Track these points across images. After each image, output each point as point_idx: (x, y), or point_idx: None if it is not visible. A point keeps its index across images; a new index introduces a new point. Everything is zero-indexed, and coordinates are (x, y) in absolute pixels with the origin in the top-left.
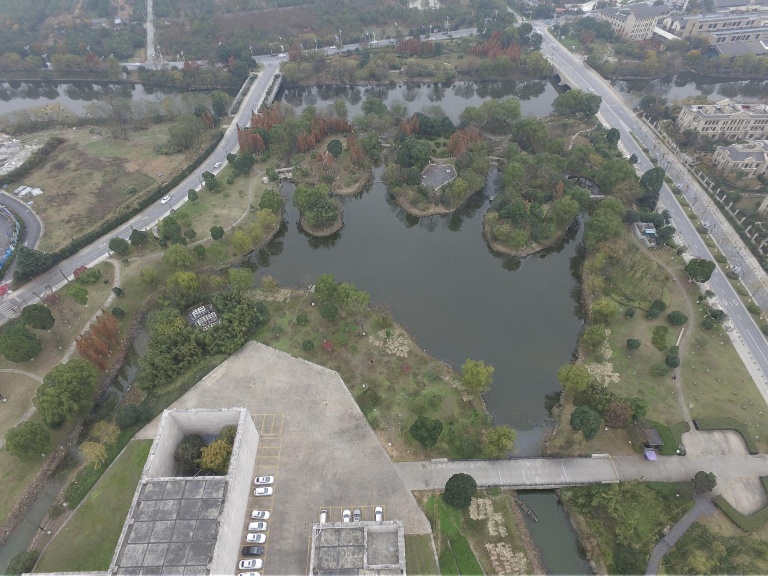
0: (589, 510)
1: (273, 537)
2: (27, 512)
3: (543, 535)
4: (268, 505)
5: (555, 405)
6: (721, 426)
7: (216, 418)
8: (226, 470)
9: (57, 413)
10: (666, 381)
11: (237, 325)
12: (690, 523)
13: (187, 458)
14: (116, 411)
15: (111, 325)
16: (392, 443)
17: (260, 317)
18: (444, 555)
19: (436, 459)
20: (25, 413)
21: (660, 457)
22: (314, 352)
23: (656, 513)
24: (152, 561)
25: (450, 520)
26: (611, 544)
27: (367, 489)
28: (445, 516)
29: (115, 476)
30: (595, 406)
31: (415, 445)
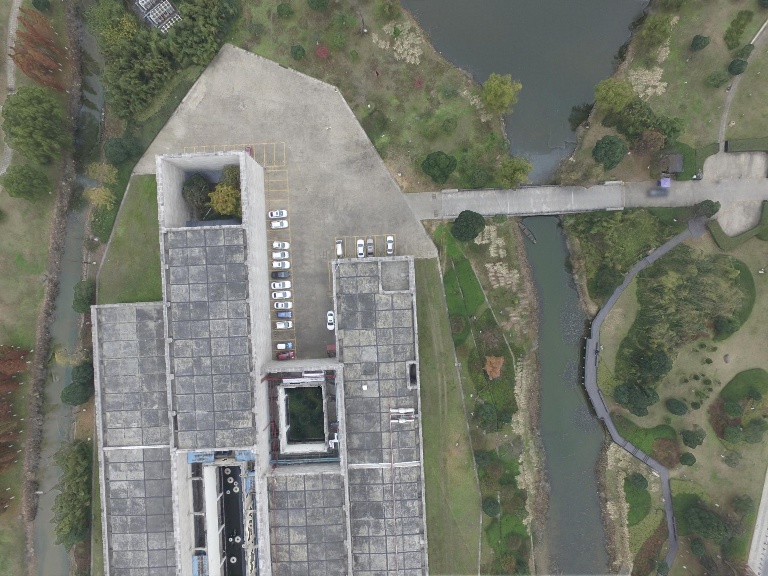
0: (586, 236)
1: (296, 263)
2: (64, 245)
3: (538, 252)
4: (286, 236)
5: (581, 124)
6: (753, 148)
7: (214, 160)
8: (239, 215)
9: (40, 154)
10: (718, 92)
11: (203, 24)
12: (675, 244)
13: (197, 204)
14: (101, 141)
15: (43, 31)
16: (402, 173)
17: (229, 9)
18: (448, 274)
19: (446, 190)
20: (4, 149)
21: (674, 182)
22: (306, 59)
23: (648, 236)
24: (197, 298)
25: (456, 245)
26: (597, 265)
27: (378, 220)
28: (451, 242)
29: (131, 213)
30: (626, 127)
31: (426, 175)
